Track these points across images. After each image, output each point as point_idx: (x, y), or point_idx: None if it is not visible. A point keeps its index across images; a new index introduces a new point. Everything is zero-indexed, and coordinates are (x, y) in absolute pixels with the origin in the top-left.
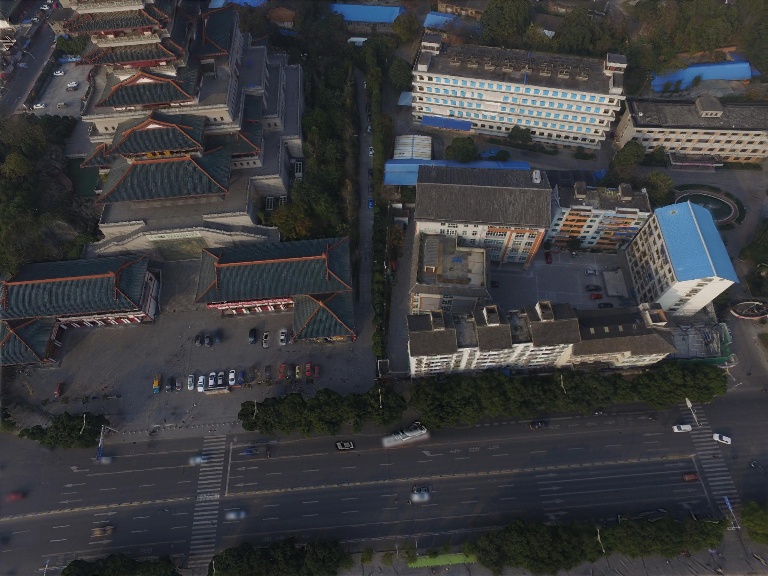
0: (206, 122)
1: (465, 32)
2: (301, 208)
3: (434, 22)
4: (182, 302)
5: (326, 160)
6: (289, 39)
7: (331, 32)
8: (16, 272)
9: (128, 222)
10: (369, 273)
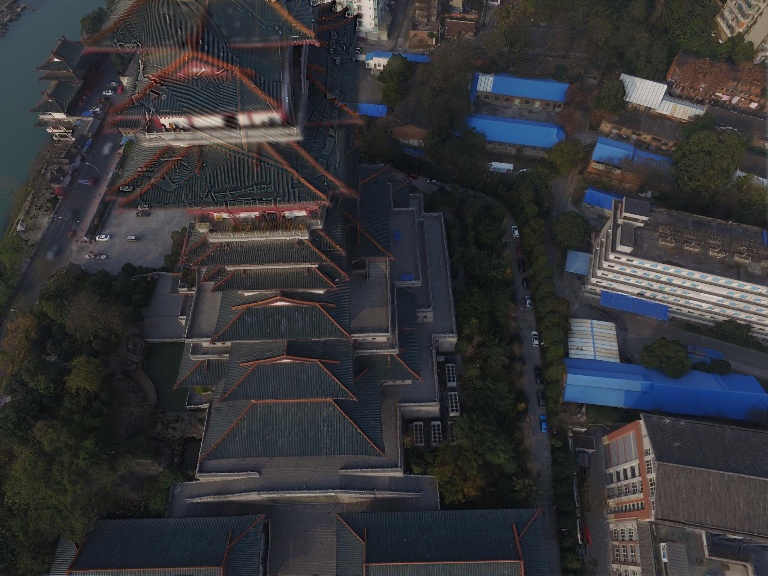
0: (354, 345)
1: (656, 179)
2: (474, 463)
3: (606, 155)
4: (298, 570)
5: (488, 365)
6: (416, 163)
7: (474, 161)
8: (82, 541)
9: (237, 473)
10: (551, 539)
